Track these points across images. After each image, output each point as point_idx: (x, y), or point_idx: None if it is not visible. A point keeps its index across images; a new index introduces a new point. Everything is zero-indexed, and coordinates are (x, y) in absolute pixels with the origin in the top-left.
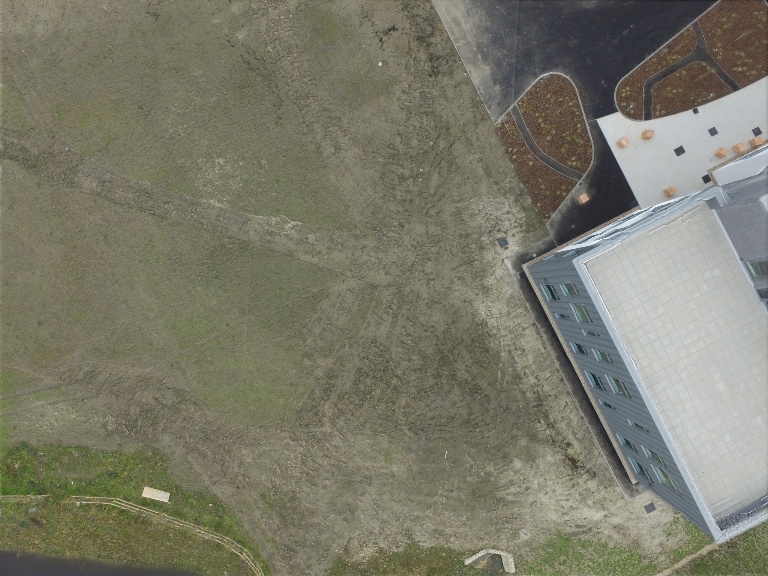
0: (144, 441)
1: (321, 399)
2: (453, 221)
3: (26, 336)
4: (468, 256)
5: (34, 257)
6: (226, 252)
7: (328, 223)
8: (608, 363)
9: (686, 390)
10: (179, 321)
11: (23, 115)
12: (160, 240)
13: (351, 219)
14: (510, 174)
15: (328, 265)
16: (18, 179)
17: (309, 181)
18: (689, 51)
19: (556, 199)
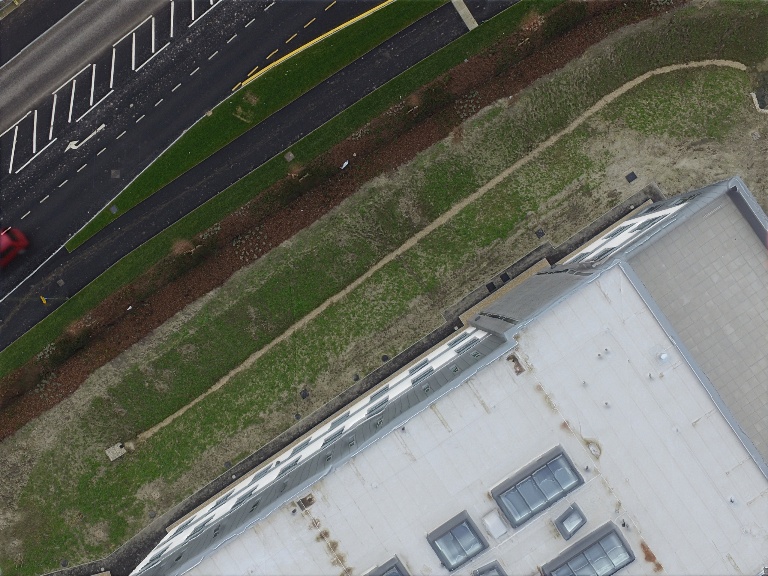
0: None
1: None
2: None
3: None
4: None
5: None
6: None
7: None
8: None
9: (765, 320)
10: None
11: None
12: None
13: None
14: None
15: None
16: None
17: None
18: None
19: None
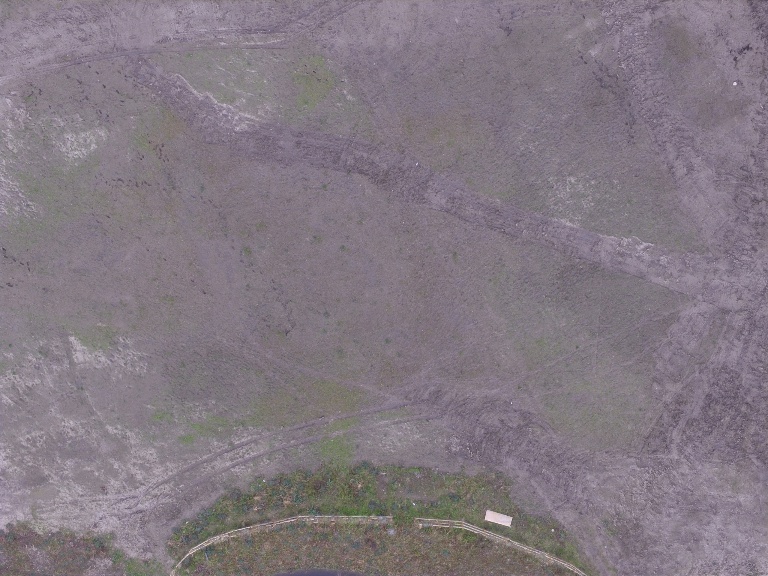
0: (488, 464)
1: (670, 425)
2: None
3: (373, 354)
4: None
5: (382, 273)
6: (576, 273)
7: (680, 245)
8: None
9: None
10: (528, 342)
11: (373, 129)
12: (510, 259)
13: (703, 242)
14: None
15: (679, 288)
16: (368, 194)
17: (661, 202)
18: None
19: None
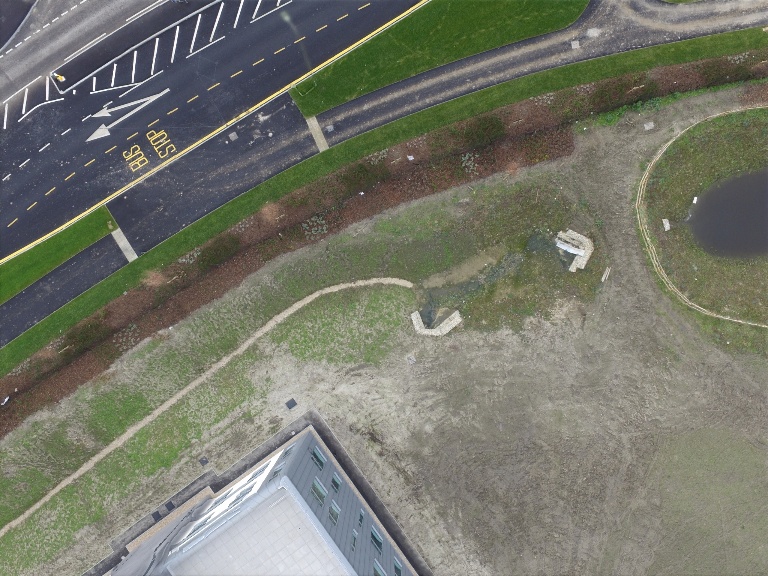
0: None
1: (636, 466)
2: None
3: None
4: None
5: None
6: None
7: None
8: None
9: None
10: None
11: None
12: None
13: None
14: None
15: None
16: None
17: None
18: None
19: None
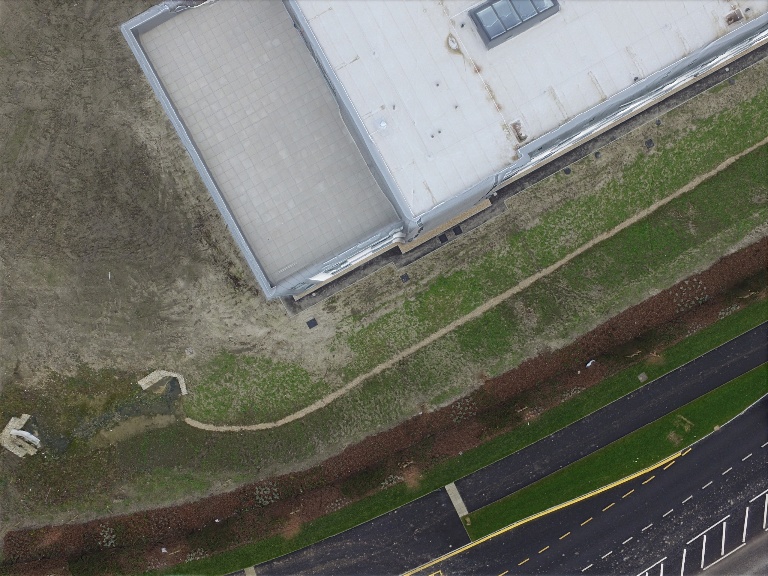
0: None
1: None
2: (109, 45)
3: None
4: (125, 80)
5: None
6: None
7: None
8: None
9: (249, 159)
10: None
11: None
12: None
13: (6, 45)
14: None
15: None
16: None
17: None
18: None
19: None
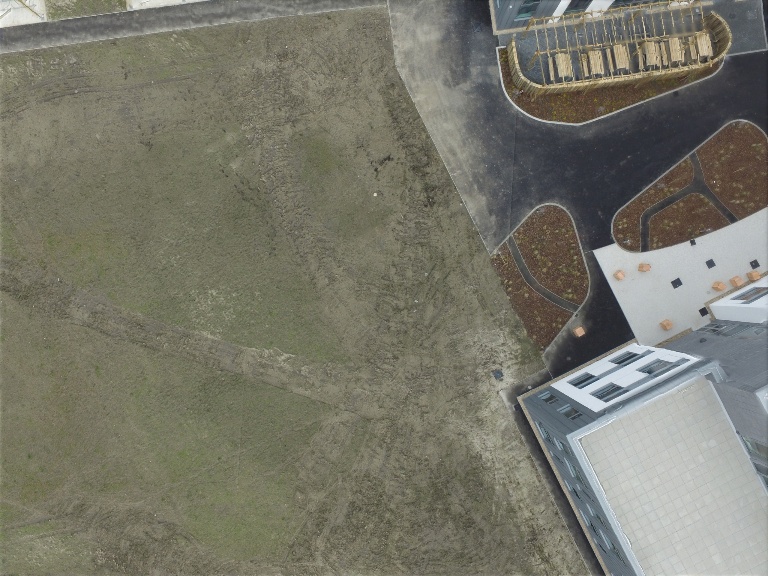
0: (134, 575)
1: (313, 533)
2: (448, 353)
3: (16, 469)
4: (463, 388)
5: (24, 389)
6: (218, 384)
7: (322, 355)
8: (603, 525)
9: (681, 563)
10: (170, 454)
11: (15, 245)
12: (152, 372)
13: (345, 351)
14: (505, 306)
15: (321, 398)
16: (9, 310)
17: (303, 313)
18: (686, 183)
19: (552, 331)
